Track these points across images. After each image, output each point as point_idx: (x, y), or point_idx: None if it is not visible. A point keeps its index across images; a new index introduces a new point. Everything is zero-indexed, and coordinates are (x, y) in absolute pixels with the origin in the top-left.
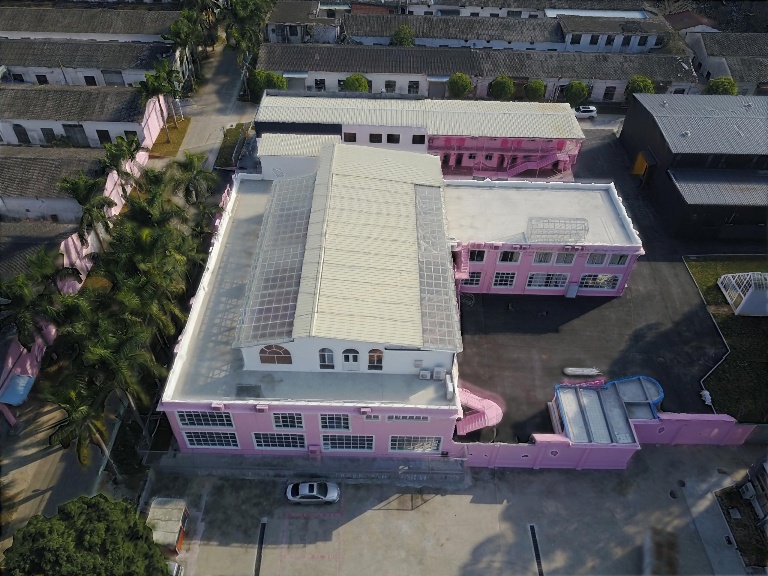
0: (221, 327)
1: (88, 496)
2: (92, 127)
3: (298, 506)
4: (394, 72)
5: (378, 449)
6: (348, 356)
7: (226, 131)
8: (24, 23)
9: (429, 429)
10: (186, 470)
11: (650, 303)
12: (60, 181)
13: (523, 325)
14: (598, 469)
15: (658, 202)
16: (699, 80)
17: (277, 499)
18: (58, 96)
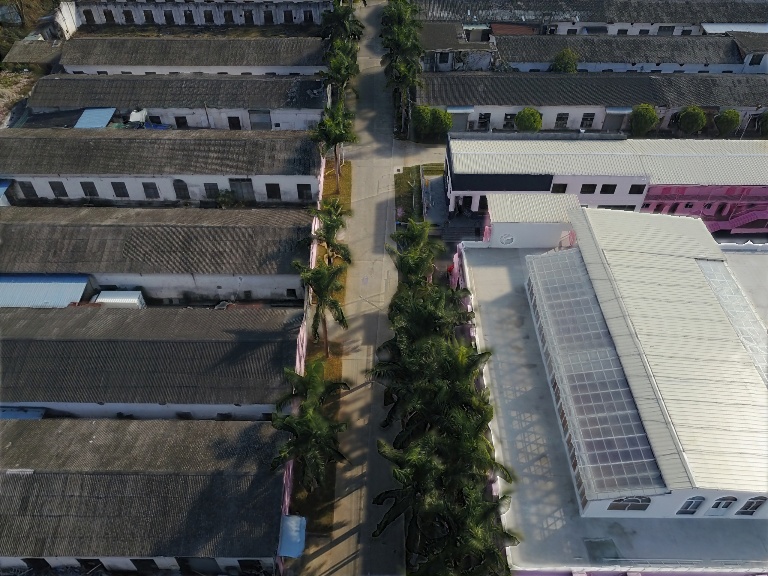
0: (528, 454)
1: None
2: (262, 181)
3: None
4: (569, 104)
5: None
6: (719, 502)
7: (394, 177)
8: (149, 56)
9: None
10: None
11: None
12: (257, 254)
13: None
14: None
15: None
16: None
17: None
18: (220, 146)
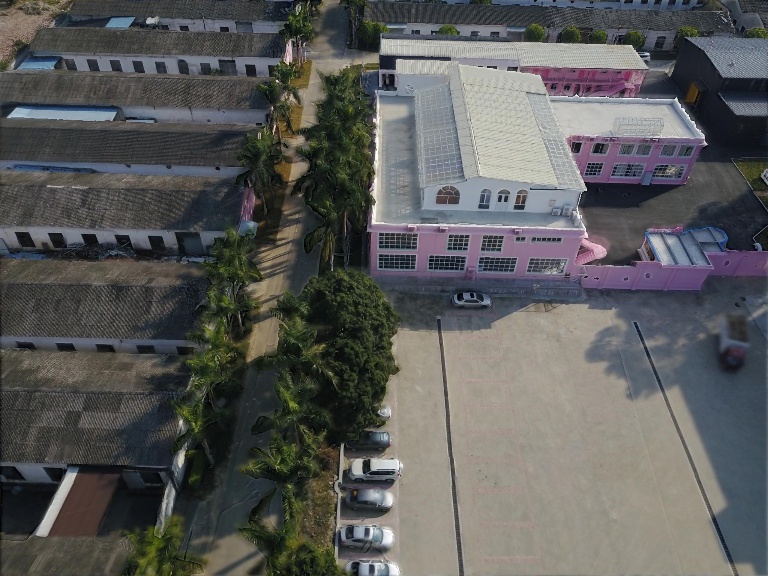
0: (397, 185)
1: None
2: (243, 62)
3: (462, 309)
4: (479, 24)
5: (518, 271)
6: (501, 197)
7: (343, 70)
8: None
9: (560, 251)
10: None
11: (709, 189)
12: (236, 97)
13: (611, 202)
14: (680, 290)
15: (709, 121)
16: (736, 32)
17: (445, 305)
18: (213, 38)
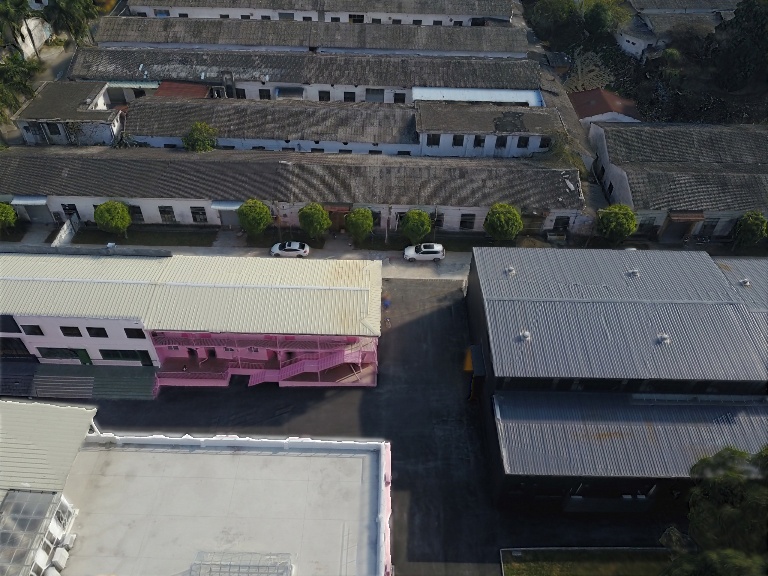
0: None
1: None
2: None
3: None
4: (166, 196)
5: None
6: None
7: None
8: None
9: None
10: None
11: None
12: None
13: None
14: None
15: (486, 434)
16: (593, 200)
17: None
18: None
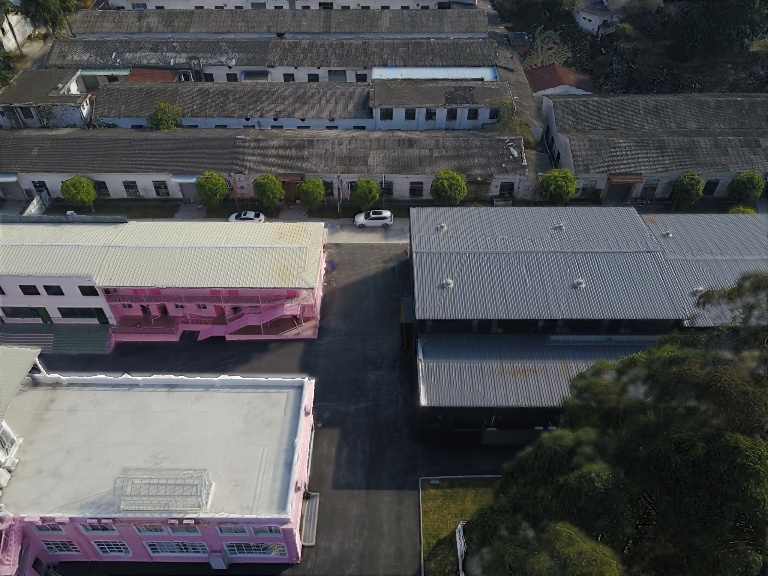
0: None
1: None
2: None
3: None
4: (128, 171)
5: None
6: None
7: None
8: None
9: None
10: None
11: None
12: None
13: None
14: None
15: None
16: (539, 167)
17: None
18: None
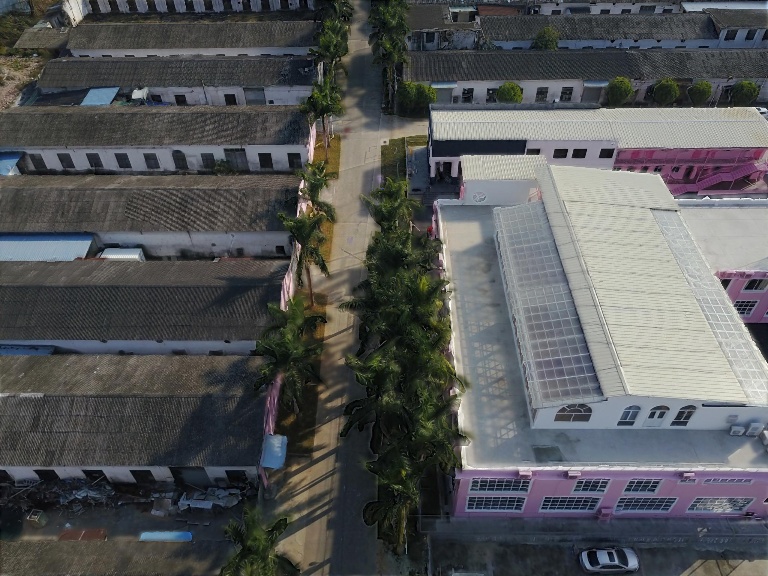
0: (487, 378)
1: (371, 569)
2: (255, 151)
3: (596, 575)
4: (548, 78)
5: (675, 510)
6: (654, 413)
7: (381, 148)
8: (151, 40)
9: (744, 491)
10: (465, 536)
11: None
12: (248, 213)
13: None
14: None
15: None
16: None
17: (569, 568)
18: (216, 119)
